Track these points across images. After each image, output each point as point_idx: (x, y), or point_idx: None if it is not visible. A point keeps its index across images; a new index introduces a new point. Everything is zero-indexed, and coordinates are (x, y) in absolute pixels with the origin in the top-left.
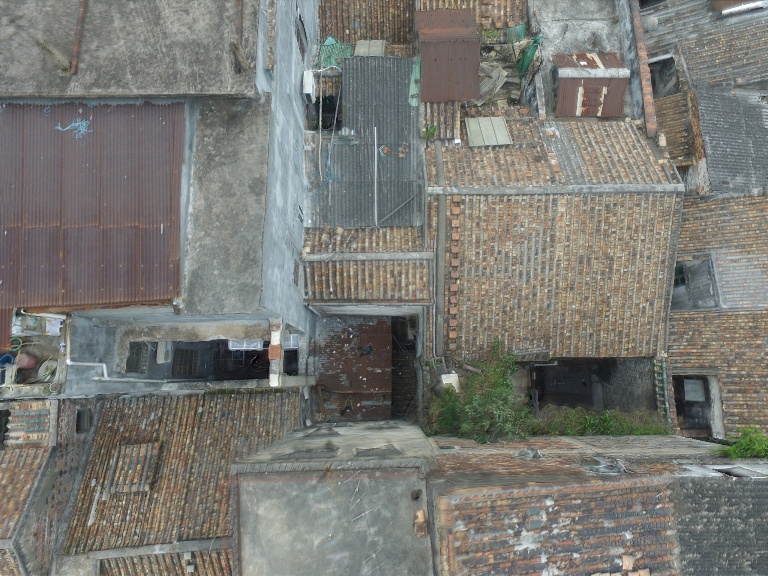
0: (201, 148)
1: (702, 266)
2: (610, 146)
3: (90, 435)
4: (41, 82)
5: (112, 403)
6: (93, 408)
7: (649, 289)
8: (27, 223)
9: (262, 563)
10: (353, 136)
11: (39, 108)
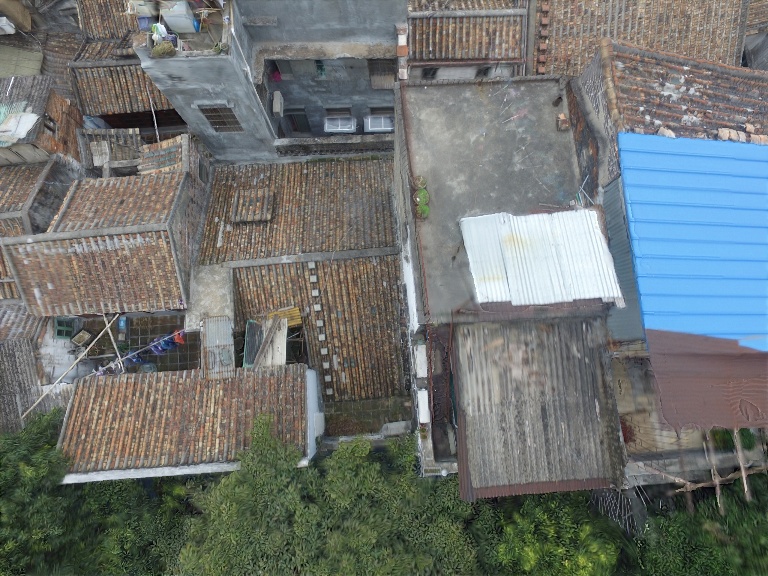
0: None
1: (767, 40)
2: None
3: (207, 188)
4: None
5: (223, 168)
6: (208, 168)
7: (722, 47)
8: None
9: (427, 154)
10: None
11: None
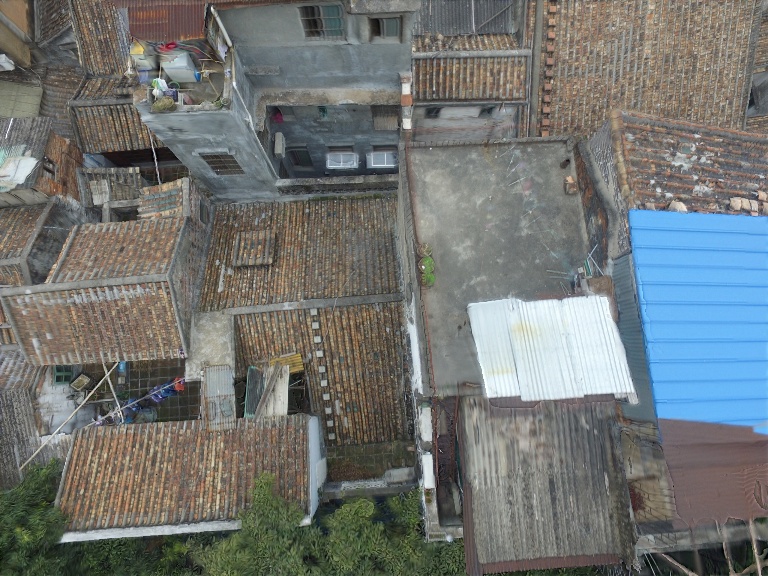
0: None
1: None
2: None
3: (208, 229)
4: None
5: (224, 207)
6: (209, 208)
7: (729, 87)
8: None
9: (432, 218)
10: None
11: None
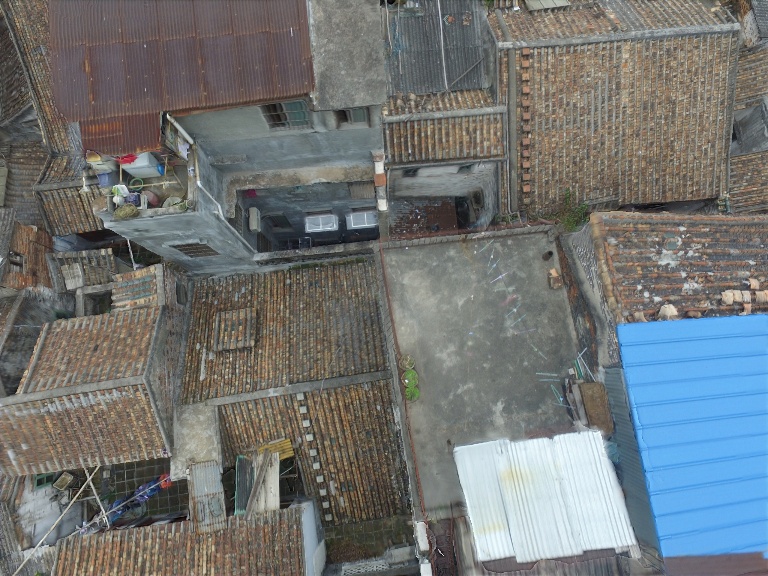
0: None
1: (754, 114)
2: (662, 2)
3: (187, 309)
4: None
5: (202, 283)
6: (186, 286)
7: (710, 130)
8: (164, 36)
9: (413, 324)
10: (418, 8)
11: None
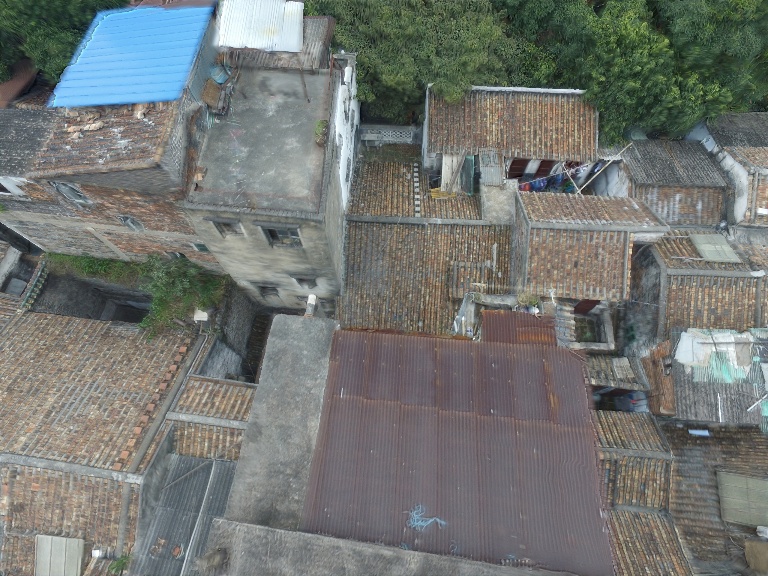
0: (303, 487)
1: None
2: None
3: None
4: (449, 575)
5: None
6: None
7: None
8: (471, 417)
9: (310, 165)
10: None
11: (463, 553)
